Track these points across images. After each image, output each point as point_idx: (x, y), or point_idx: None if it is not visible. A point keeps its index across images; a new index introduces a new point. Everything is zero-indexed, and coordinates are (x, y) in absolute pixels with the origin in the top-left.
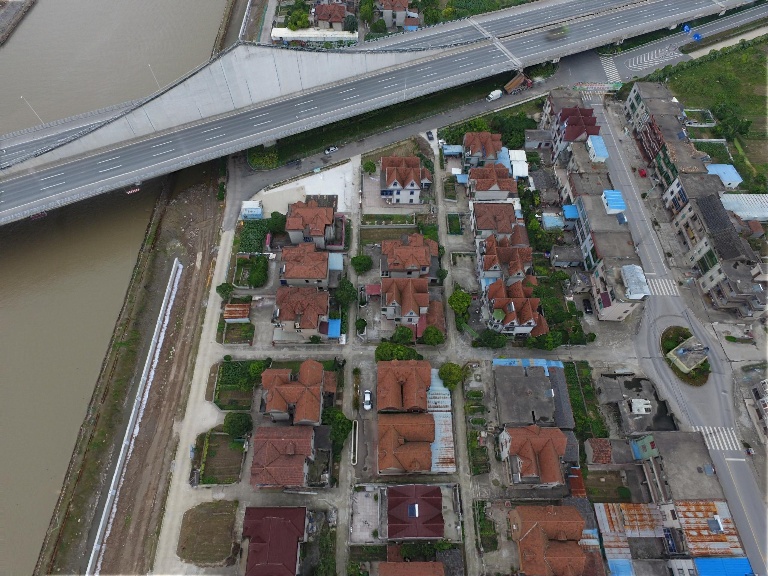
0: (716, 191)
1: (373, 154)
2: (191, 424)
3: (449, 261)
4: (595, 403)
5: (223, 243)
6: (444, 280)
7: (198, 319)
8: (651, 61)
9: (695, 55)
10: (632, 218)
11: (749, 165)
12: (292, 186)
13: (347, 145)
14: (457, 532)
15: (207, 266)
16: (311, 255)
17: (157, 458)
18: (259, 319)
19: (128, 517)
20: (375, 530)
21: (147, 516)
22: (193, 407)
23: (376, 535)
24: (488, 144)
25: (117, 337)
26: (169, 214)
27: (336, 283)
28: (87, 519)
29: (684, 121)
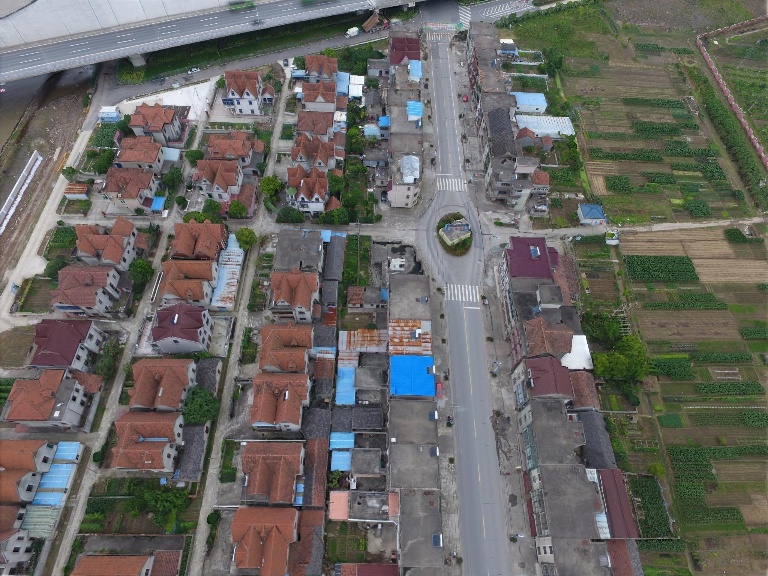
0: (508, 107)
1: None
2: (21, 271)
3: (275, 159)
4: (368, 266)
5: (79, 140)
6: (266, 173)
7: (44, 196)
8: (504, 11)
9: (545, 8)
10: (445, 133)
11: (562, 96)
12: (152, 98)
13: (210, 68)
14: (224, 350)
15: (63, 158)
16: (144, 144)
17: None
18: (97, 197)
19: None
20: None
21: None
22: (25, 259)
23: None
24: (323, 65)
25: None
26: (37, 117)
27: (168, 170)
28: None
29: (515, 59)
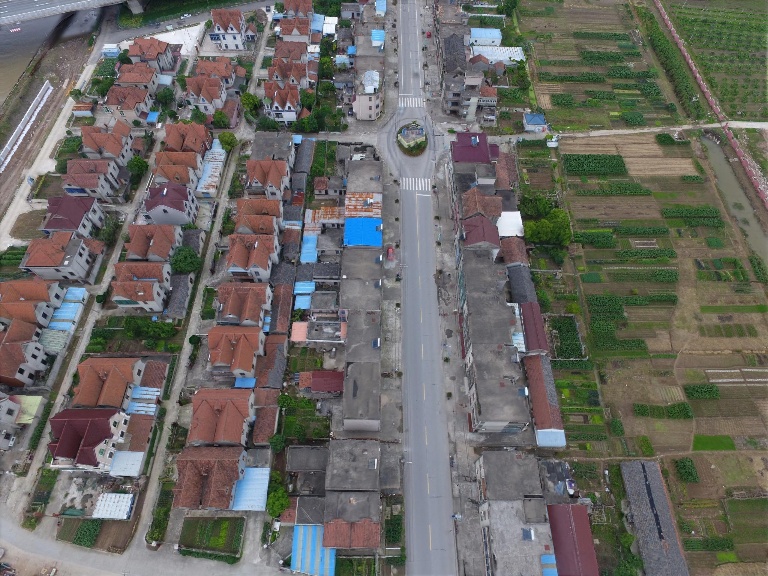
0: (463, 35)
1: None
2: (35, 170)
3: None
4: (334, 164)
5: (85, 72)
6: None
7: None
8: None
9: None
10: (409, 62)
11: (518, 32)
12: None
13: (200, 14)
14: (208, 226)
15: None
16: (141, 68)
17: (8, 189)
18: (101, 115)
19: None
20: None
21: None
22: (39, 161)
23: None
24: None
25: None
26: (49, 55)
27: None
28: None
29: (476, 2)
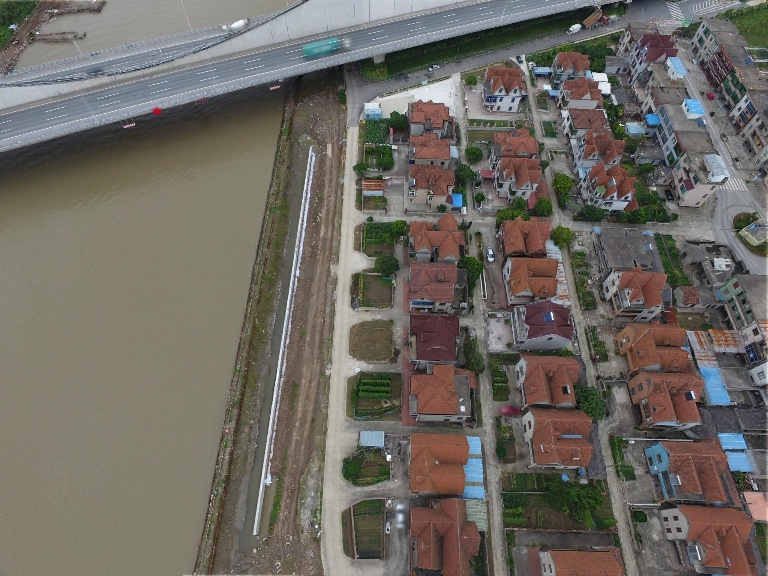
0: None
1: (470, 73)
2: (345, 266)
3: (547, 157)
4: (680, 265)
5: (350, 136)
6: (544, 171)
7: (338, 192)
8: (712, 7)
9: (752, 4)
10: None
11: None
12: (403, 95)
13: (447, 65)
14: (574, 348)
15: (337, 154)
16: (436, 141)
17: (320, 290)
18: (390, 194)
19: (303, 330)
20: (509, 343)
21: (319, 329)
22: (345, 255)
23: (510, 346)
24: (578, 62)
25: (271, 203)
26: (298, 113)
27: (454, 167)
28: (269, 331)
29: None
